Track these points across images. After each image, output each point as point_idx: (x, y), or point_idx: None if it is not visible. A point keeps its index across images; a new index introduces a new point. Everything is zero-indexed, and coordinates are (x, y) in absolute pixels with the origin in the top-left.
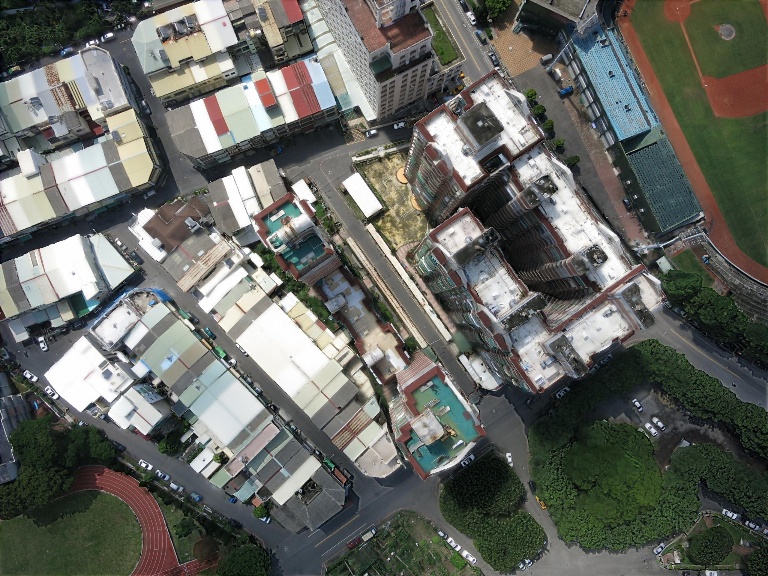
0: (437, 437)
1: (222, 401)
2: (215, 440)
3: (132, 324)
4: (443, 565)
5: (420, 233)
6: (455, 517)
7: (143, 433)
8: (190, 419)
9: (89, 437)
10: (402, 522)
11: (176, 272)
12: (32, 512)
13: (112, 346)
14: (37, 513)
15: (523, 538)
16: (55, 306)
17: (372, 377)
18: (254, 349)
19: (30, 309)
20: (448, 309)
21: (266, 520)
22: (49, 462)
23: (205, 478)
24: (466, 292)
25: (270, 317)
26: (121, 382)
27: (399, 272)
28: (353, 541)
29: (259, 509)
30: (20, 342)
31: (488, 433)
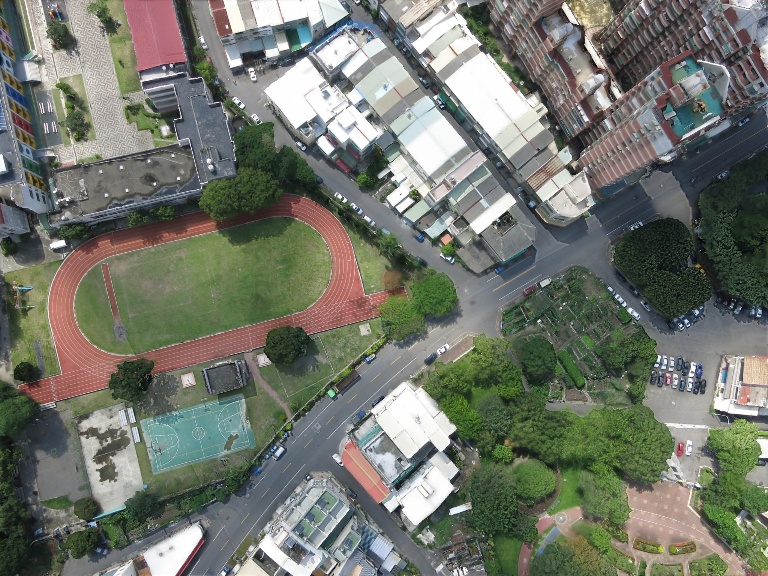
0: (707, 87)
1: (431, 132)
2: (410, 179)
3: (352, 53)
4: (609, 319)
5: (605, 19)
6: (635, 261)
7: (360, 147)
8: (389, 157)
9: (297, 158)
10: (576, 275)
11: (395, 12)
12: (228, 231)
13: (333, 69)
14: (233, 233)
15: (695, 286)
16: (272, 37)
17: (556, 140)
18: (462, 90)
19: (254, 30)
20: (629, 86)
21: (451, 260)
22: (269, 164)
23: (395, 216)
24: (706, 3)
25: (479, 63)
26: (338, 103)
27: (587, 48)
28: (529, 288)
29: (449, 245)
30: (230, 71)
31: (656, 204)
